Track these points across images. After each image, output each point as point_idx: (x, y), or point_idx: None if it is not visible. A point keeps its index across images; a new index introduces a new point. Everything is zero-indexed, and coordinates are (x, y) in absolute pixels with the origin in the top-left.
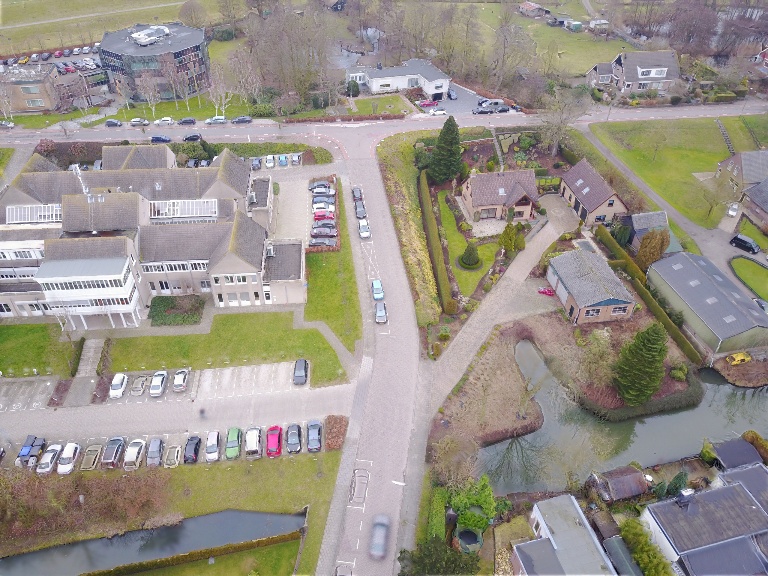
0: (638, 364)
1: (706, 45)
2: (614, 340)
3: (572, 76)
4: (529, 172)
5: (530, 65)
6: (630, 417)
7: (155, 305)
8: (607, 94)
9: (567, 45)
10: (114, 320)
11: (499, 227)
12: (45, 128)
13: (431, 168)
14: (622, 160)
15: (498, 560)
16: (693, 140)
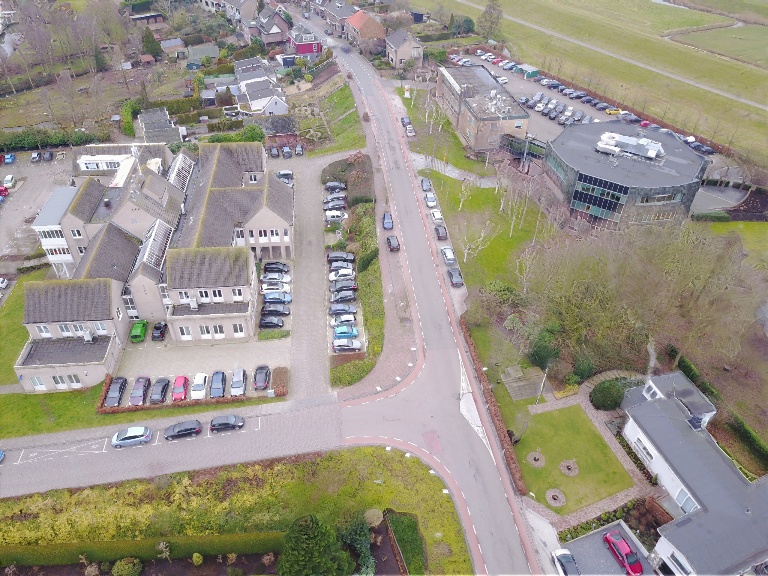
0: None
1: None
2: None
3: None
4: None
5: None
6: None
7: None
8: None
9: None
10: None
11: None
12: (412, 152)
13: None
14: None
15: None
16: None
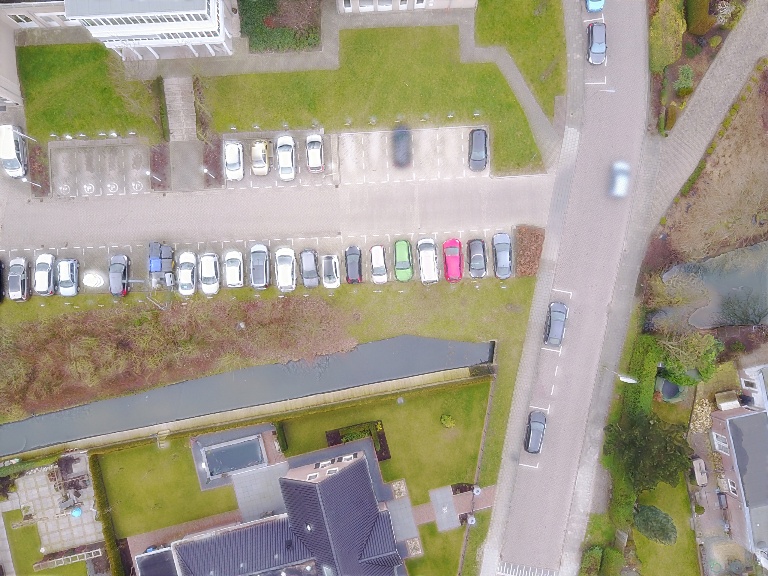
0: None
1: None
2: None
3: None
4: None
5: None
6: None
7: (246, 9)
8: None
9: None
10: (196, 48)
11: None
12: None
13: None
14: None
15: (697, 412)
16: None
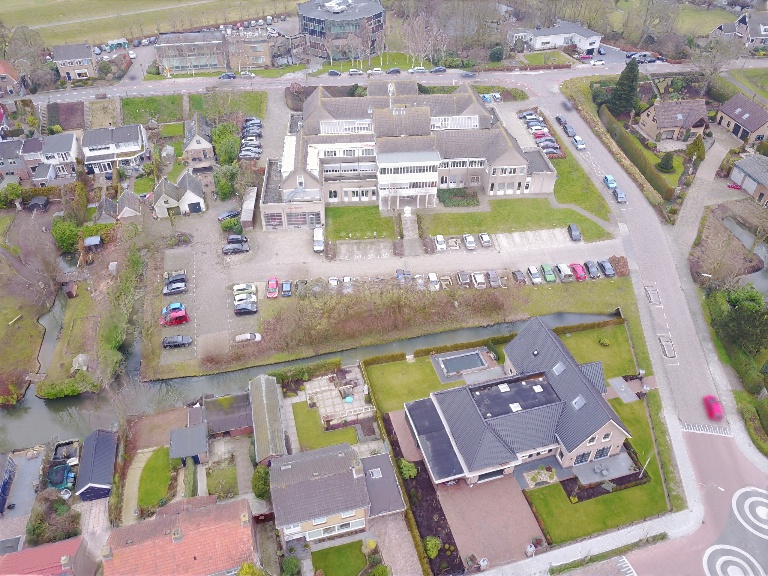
0: None
1: None
2: None
3: None
4: (701, 101)
5: (651, 29)
6: None
7: (441, 194)
8: None
9: None
10: (420, 201)
11: (678, 145)
12: (280, 77)
13: (611, 102)
14: (763, 97)
15: None
16: None
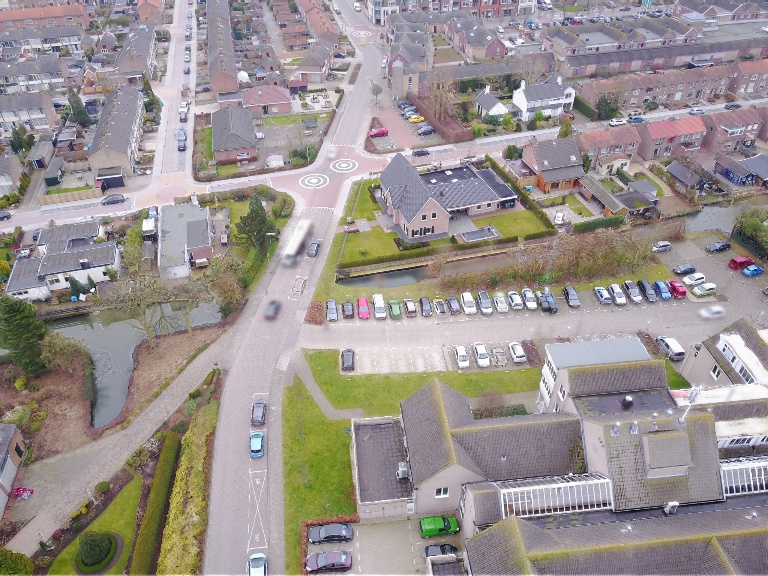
0: None
1: None
2: (5, 411)
3: None
4: None
5: None
6: None
7: None
8: None
9: None
10: None
11: None
12: None
13: None
14: None
15: None
16: None
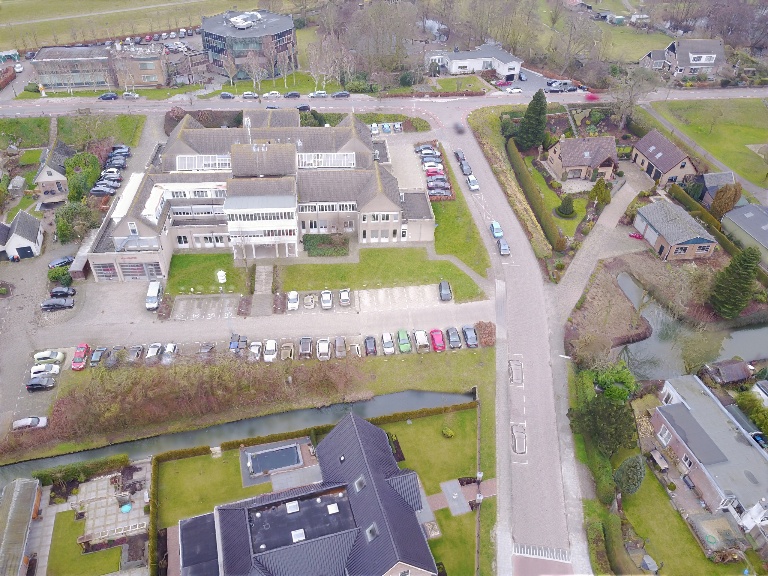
0: (734, 281)
1: (744, 37)
2: None
3: (624, 63)
4: (610, 138)
5: None
6: (724, 329)
7: (308, 240)
8: (662, 77)
9: (612, 37)
10: (279, 250)
11: (584, 186)
12: (167, 99)
13: (519, 136)
14: (684, 132)
15: (639, 422)
16: (743, 117)
